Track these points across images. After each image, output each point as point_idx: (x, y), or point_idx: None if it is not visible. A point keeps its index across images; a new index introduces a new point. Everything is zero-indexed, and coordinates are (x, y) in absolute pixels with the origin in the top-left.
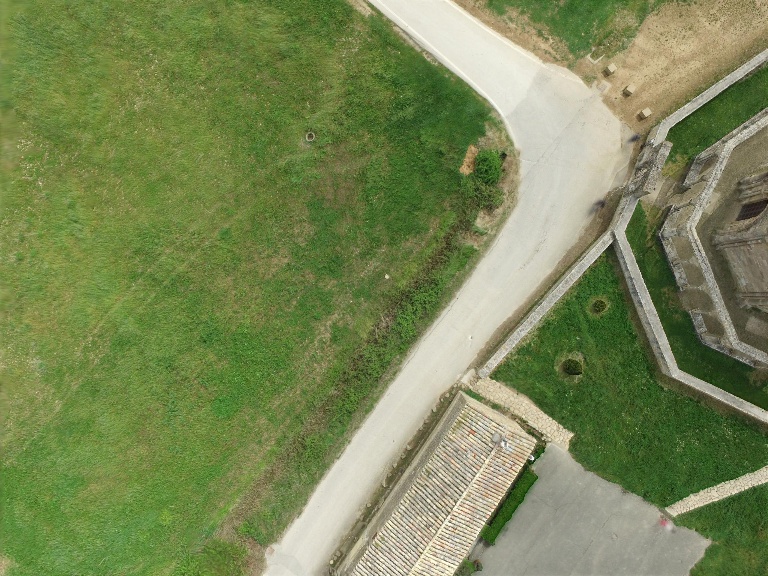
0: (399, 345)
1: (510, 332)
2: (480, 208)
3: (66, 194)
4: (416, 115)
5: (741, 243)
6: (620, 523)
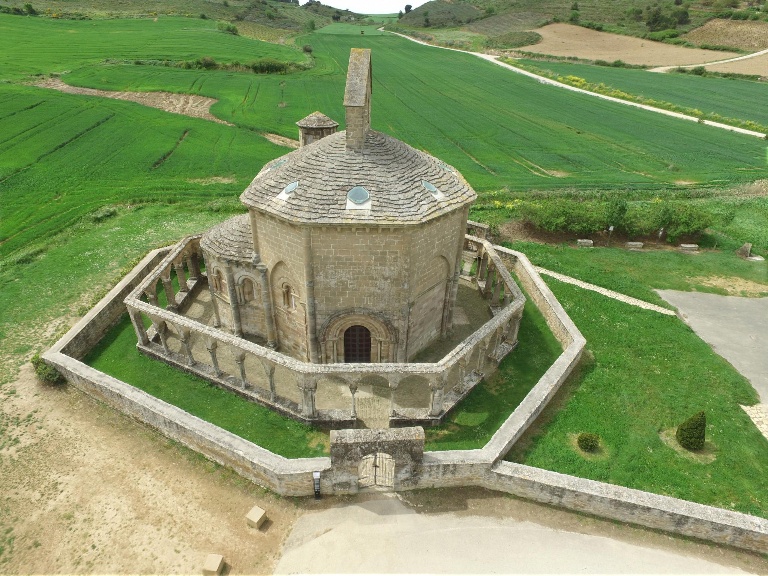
0: None
1: (762, 553)
2: None
3: None
4: None
5: (409, 334)
6: (738, 339)
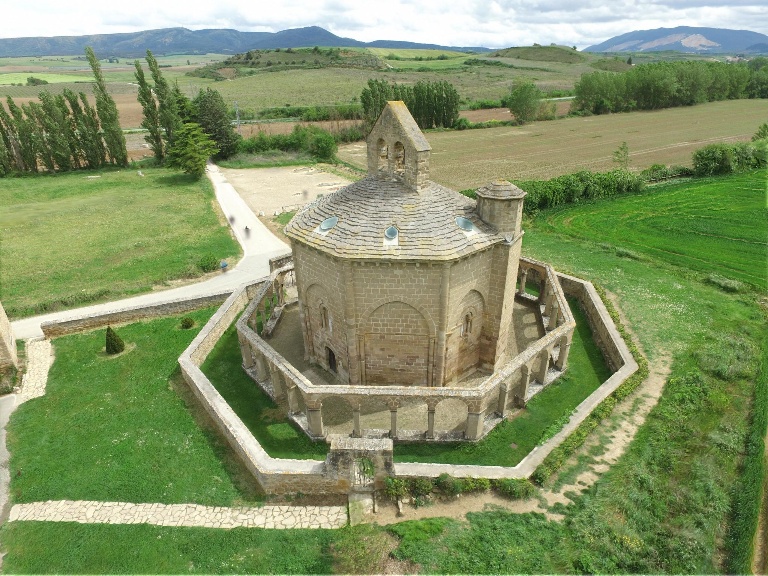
0: (28, 309)
1: None
2: (181, 277)
3: (1, 235)
4: (199, 247)
5: None
6: None
